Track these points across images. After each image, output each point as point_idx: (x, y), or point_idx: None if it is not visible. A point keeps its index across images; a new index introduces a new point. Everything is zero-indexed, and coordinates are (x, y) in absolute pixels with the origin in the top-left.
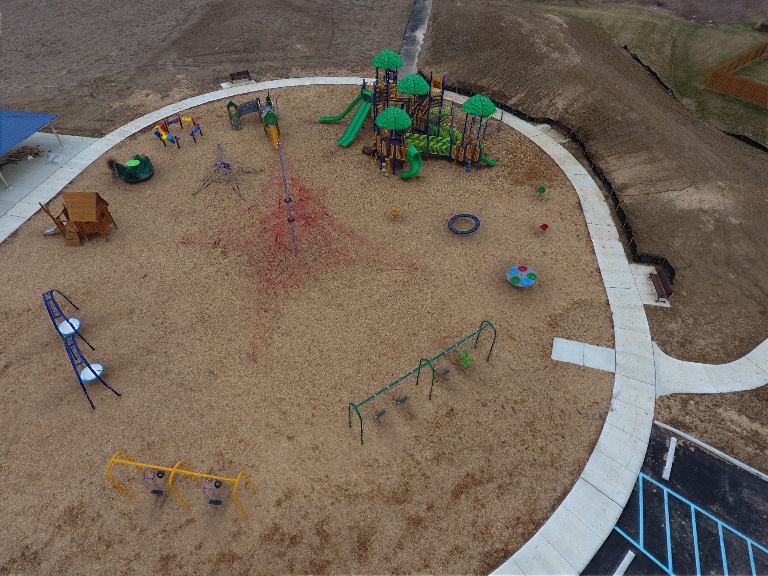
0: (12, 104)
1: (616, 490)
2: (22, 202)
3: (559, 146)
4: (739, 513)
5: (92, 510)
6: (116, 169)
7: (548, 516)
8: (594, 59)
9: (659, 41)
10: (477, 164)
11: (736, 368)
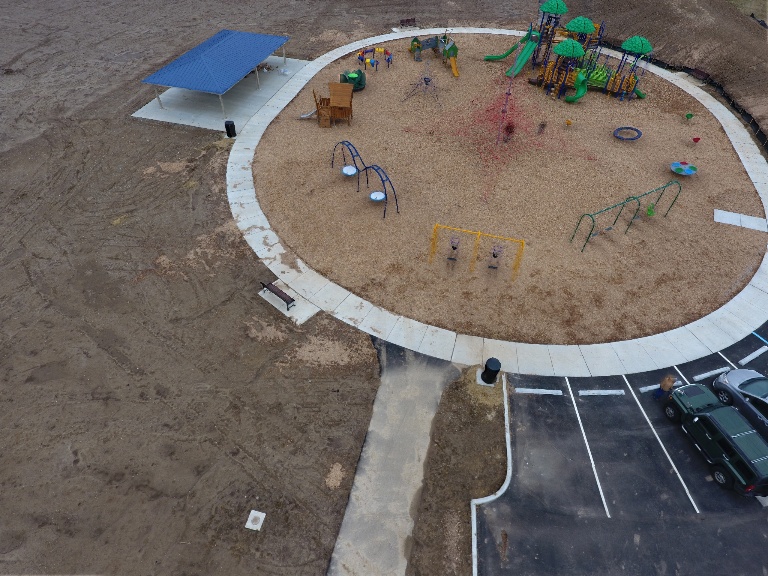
0: None
1: None
2: (273, 98)
3: (698, 88)
4: None
5: (407, 267)
6: None
7: (728, 300)
8: (727, 21)
9: None
10: (628, 96)
11: None
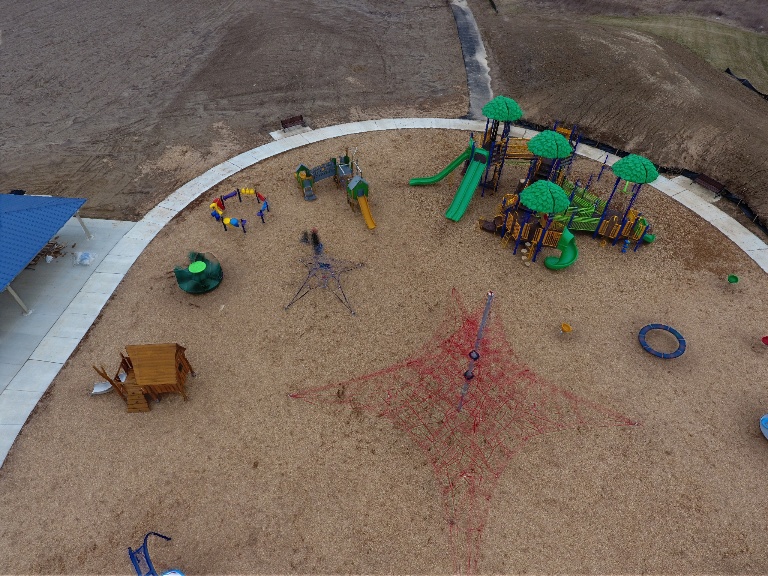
0: (10, 172)
1: None
2: (50, 335)
3: (713, 207)
4: None
5: None
6: (170, 271)
7: None
8: (714, 90)
9: (749, 59)
10: (629, 240)
11: None
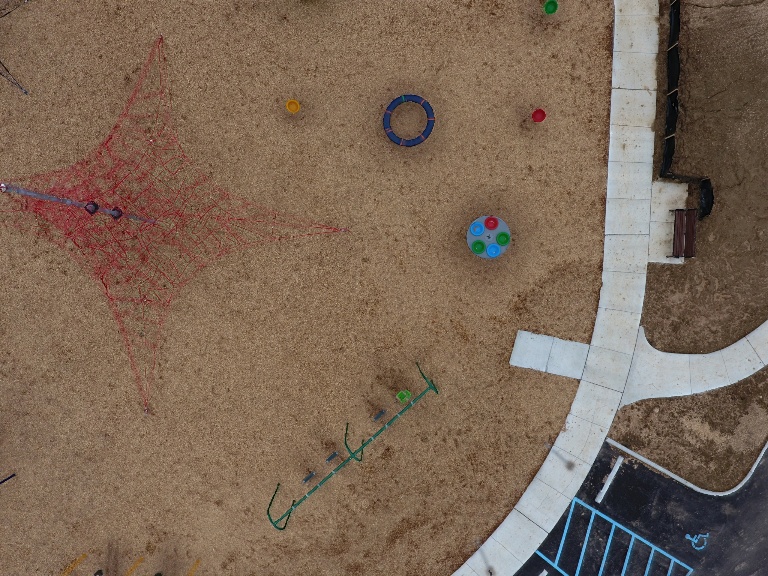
0: None
1: (546, 518)
2: None
3: None
4: (656, 525)
5: None
6: None
7: (476, 548)
8: None
9: None
10: None
11: (727, 356)
